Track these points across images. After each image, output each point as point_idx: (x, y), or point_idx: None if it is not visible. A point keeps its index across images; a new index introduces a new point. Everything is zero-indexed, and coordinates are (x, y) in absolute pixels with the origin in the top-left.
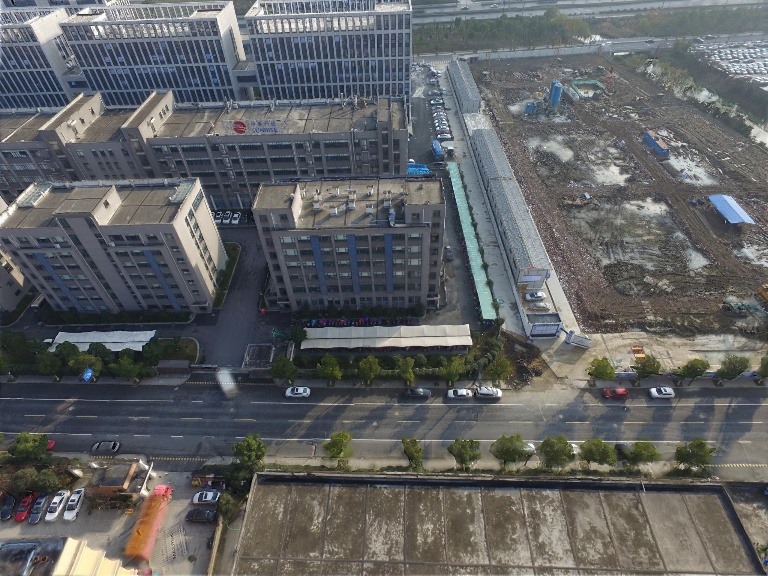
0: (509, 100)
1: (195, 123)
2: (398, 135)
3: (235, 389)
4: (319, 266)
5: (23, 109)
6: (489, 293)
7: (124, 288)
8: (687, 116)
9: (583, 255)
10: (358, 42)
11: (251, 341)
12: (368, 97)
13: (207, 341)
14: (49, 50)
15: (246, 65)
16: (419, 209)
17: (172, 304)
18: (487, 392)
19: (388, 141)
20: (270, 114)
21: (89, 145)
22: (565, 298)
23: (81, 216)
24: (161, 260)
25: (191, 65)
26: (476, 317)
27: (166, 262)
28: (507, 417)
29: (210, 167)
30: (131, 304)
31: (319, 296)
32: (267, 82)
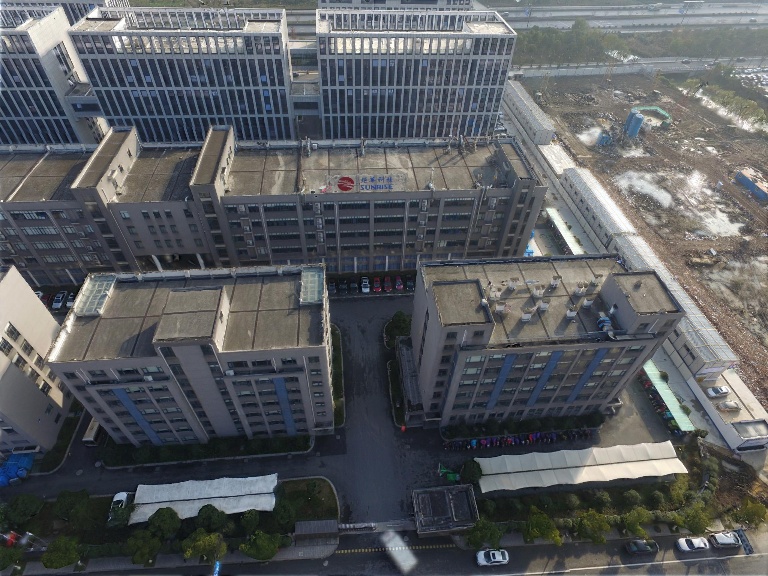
0: (574, 127)
1: (272, 171)
2: (535, 192)
3: (407, 558)
4: (500, 383)
5: (25, 146)
6: (670, 391)
7: (225, 415)
8: (765, 151)
9: (743, 331)
10: (448, 67)
11: (402, 477)
12: (475, 138)
13: (343, 480)
14: (49, 64)
15: (302, 88)
16: (652, 319)
17: (287, 429)
18: (728, 541)
19: (525, 200)
20: (363, 159)
21: (140, 205)
22: (749, 391)
23: (196, 343)
24: (293, 386)
25: (240, 88)
26: (662, 423)
27: (300, 388)
28: (761, 575)
29: (296, 229)
30: (228, 430)
31: (482, 411)
32: (332, 110)
